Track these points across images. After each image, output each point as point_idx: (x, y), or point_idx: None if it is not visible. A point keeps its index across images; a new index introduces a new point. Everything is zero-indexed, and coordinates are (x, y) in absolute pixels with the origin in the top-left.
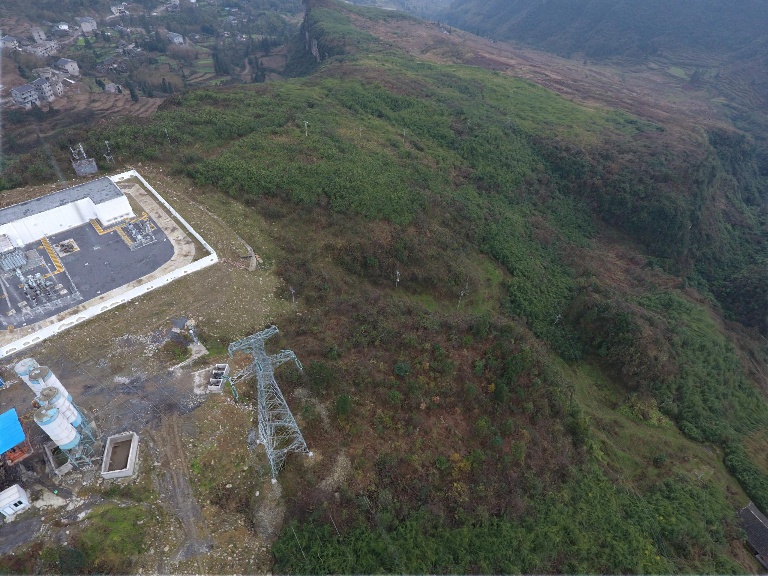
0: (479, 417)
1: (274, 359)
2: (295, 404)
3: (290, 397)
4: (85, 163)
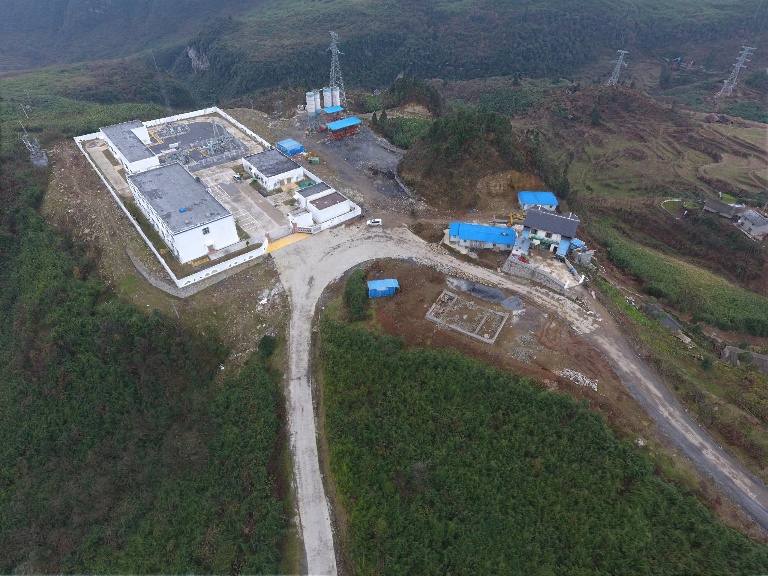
0: None
1: None
2: None
3: None
4: (39, 155)
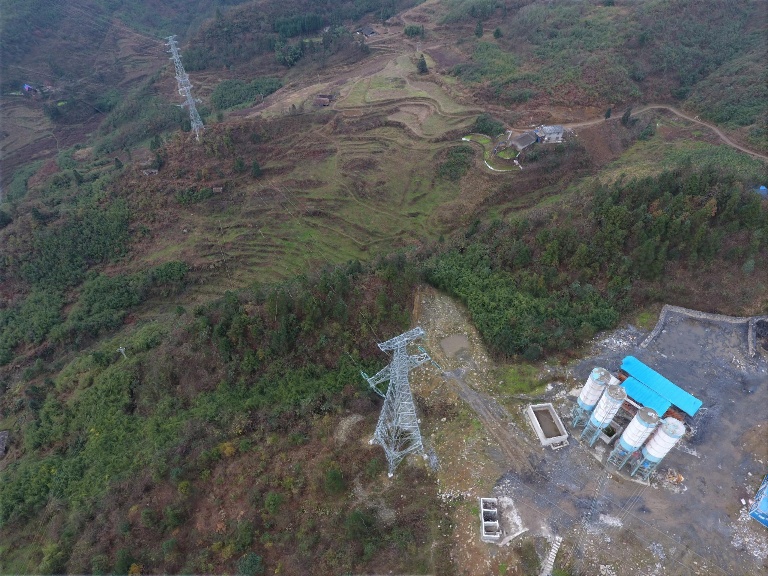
0: (177, 524)
1: (388, 368)
2: (392, 500)
3: (399, 510)
4: None
